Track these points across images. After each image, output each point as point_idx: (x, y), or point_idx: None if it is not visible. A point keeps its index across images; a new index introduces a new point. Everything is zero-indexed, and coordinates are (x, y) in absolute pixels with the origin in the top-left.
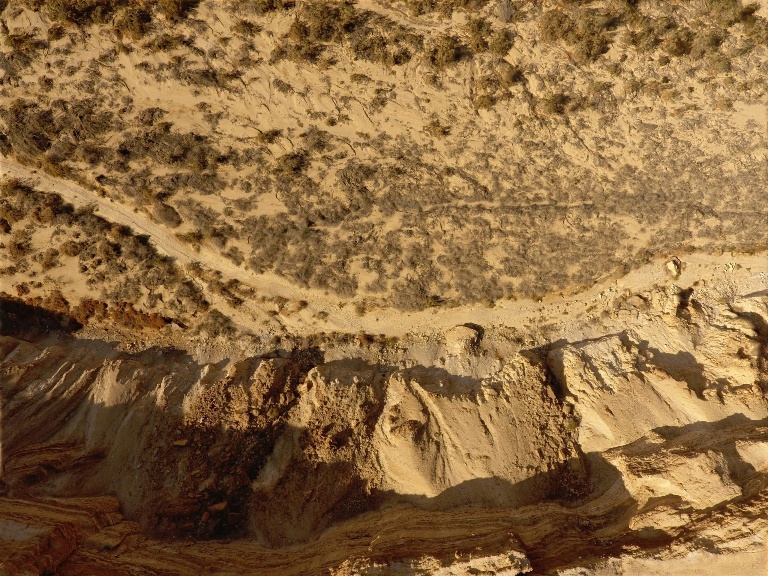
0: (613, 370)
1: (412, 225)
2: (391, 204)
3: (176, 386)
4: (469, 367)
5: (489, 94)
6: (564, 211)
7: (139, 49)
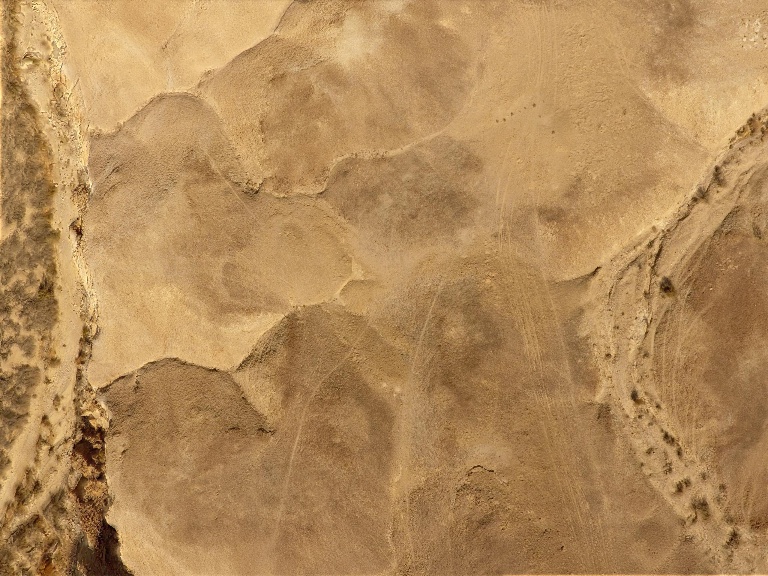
0: None
1: None
2: None
3: None
4: None
5: None
6: None
7: None
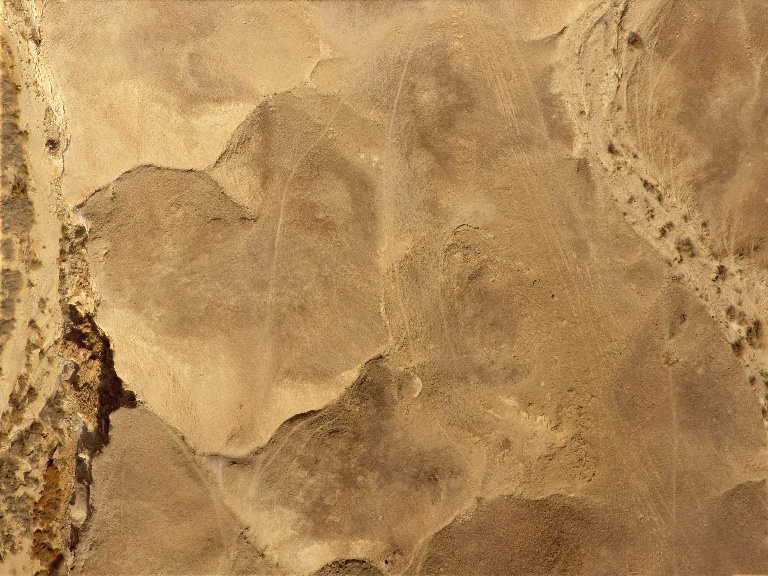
0: None
1: None
2: None
3: None
4: None
5: None
6: None
7: None
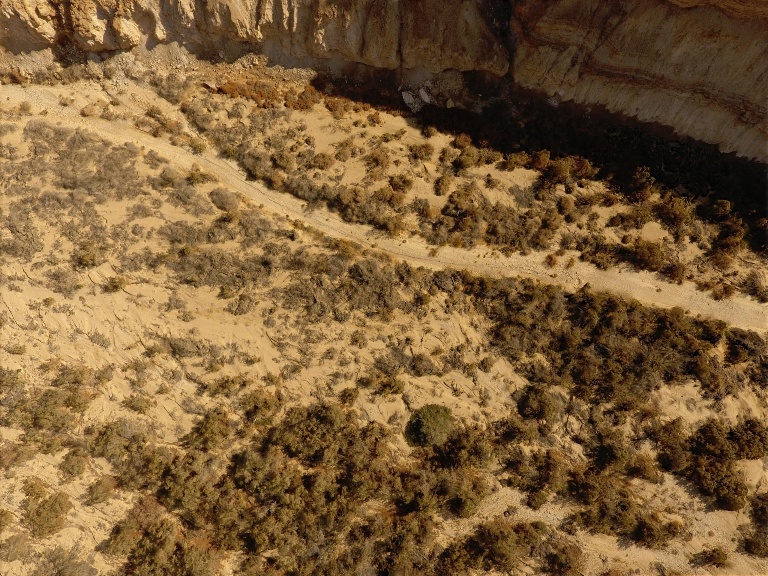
0: None
1: None
2: None
3: (173, 6)
4: None
5: None
6: None
7: (256, 379)
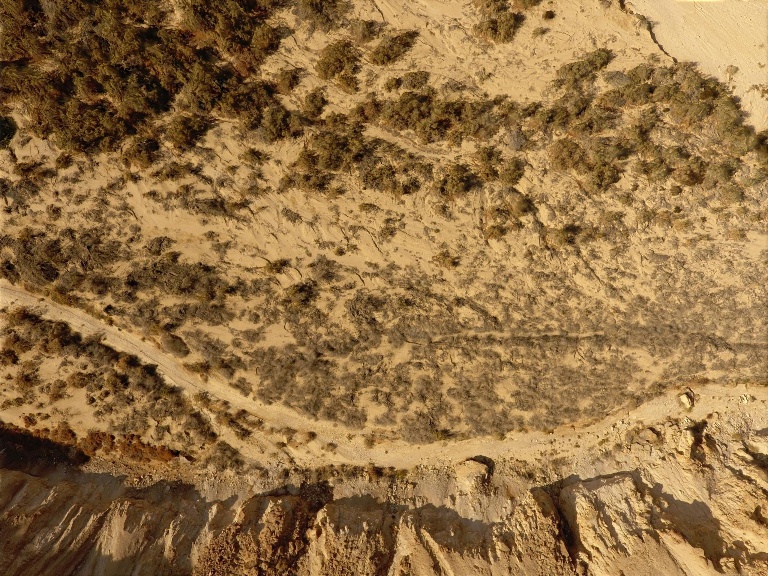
0: (627, 524)
1: (422, 357)
2: (400, 335)
3: (184, 533)
4: (480, 509)
5: (499, 224)
6: (575, 343)
7: (147, 178)
